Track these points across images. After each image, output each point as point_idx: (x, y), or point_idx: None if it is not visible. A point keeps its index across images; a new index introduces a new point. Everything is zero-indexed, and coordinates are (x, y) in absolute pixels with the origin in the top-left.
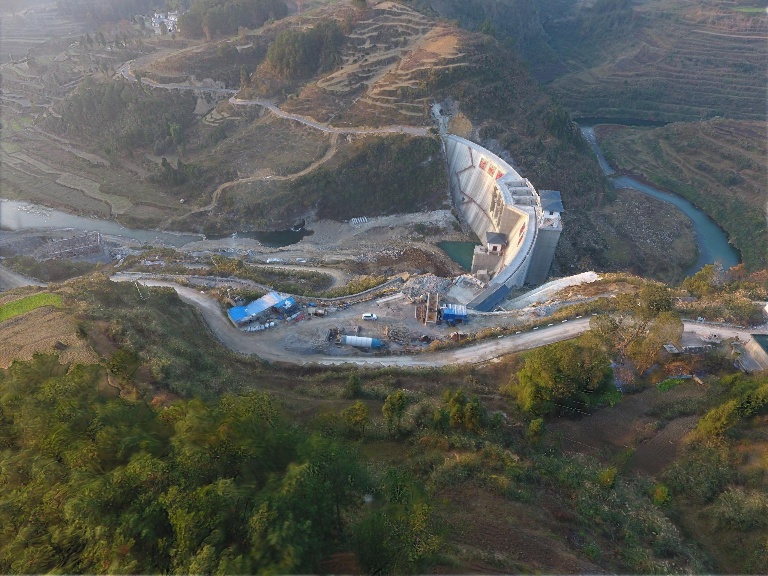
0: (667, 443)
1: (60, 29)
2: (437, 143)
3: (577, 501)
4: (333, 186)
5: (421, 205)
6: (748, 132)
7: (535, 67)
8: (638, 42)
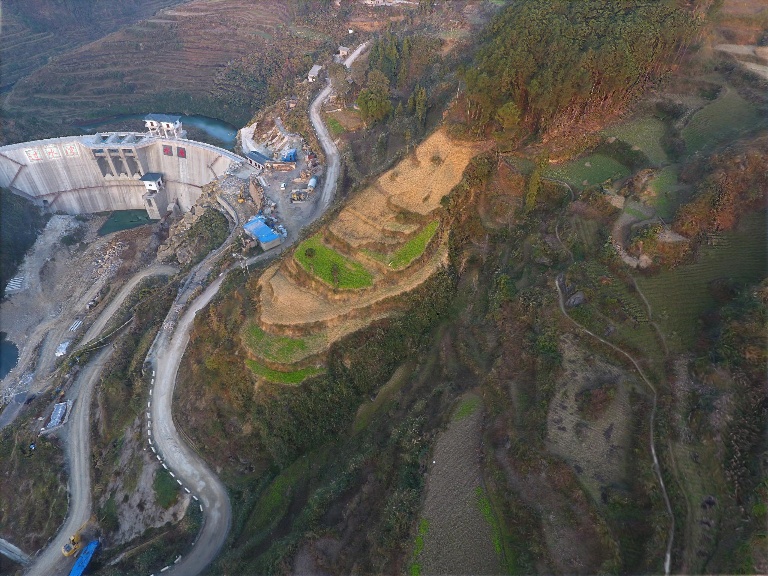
0: None
1: None
2: None
3: None
4: None
5: (30, 231)
6: (86, 57)
7: None
8: None
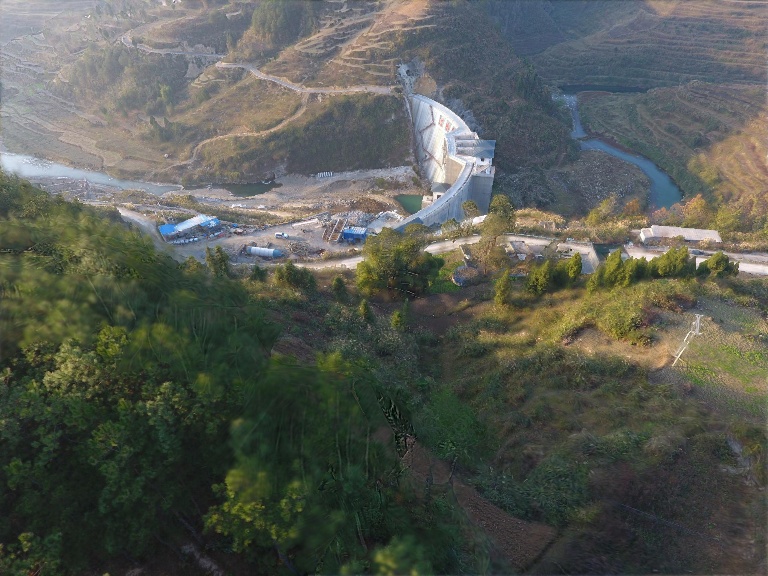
0: (470, 315)
1: (78, 3)
2: (400, 101)
3: (324, 317)
4: (301, 142)
5: (385, 161)
6: (722, 95)
7: (531, 36)
8: (636, 9)
